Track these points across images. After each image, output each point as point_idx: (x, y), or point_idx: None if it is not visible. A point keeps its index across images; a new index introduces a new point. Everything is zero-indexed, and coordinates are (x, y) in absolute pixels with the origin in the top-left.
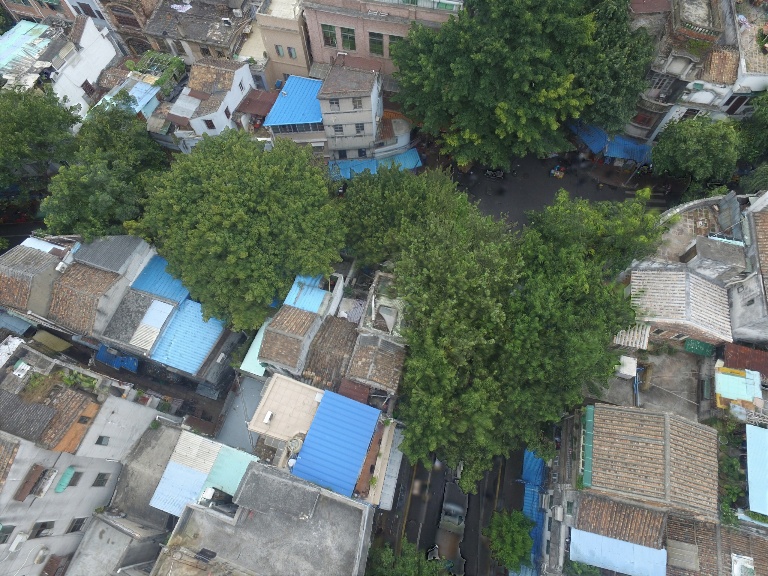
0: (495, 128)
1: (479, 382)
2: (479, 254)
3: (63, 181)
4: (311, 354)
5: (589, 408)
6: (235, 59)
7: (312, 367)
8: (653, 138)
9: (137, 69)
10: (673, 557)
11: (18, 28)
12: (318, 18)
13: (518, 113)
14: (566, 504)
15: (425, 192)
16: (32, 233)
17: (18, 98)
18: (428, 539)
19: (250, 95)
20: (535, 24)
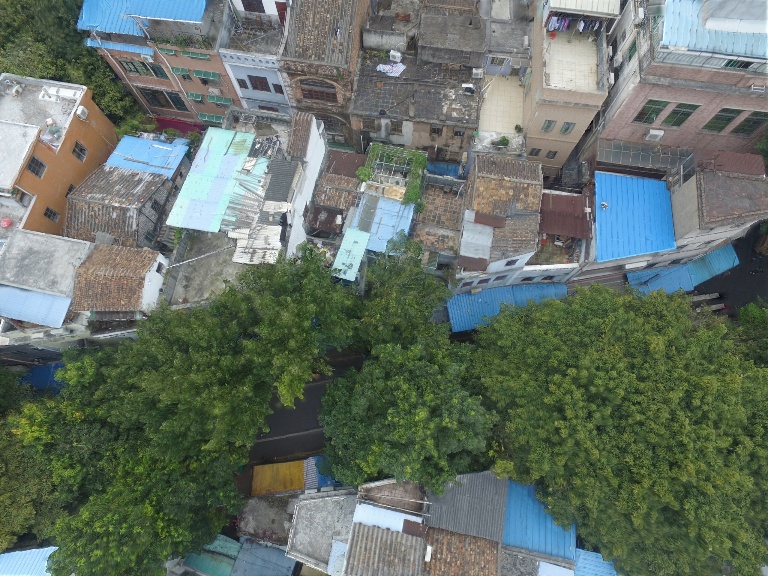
0: None
1: None
2: None
3: (428, 437)
4: None
5: None
6: (476, 138)
7: None
8: None
9: (369, 176)
10: None
11: (212, 144)
12: (650, 93)
13: None
14: None
15: None
16: (359, 495)
17: (282, 281)
18: None
19: None
20: None
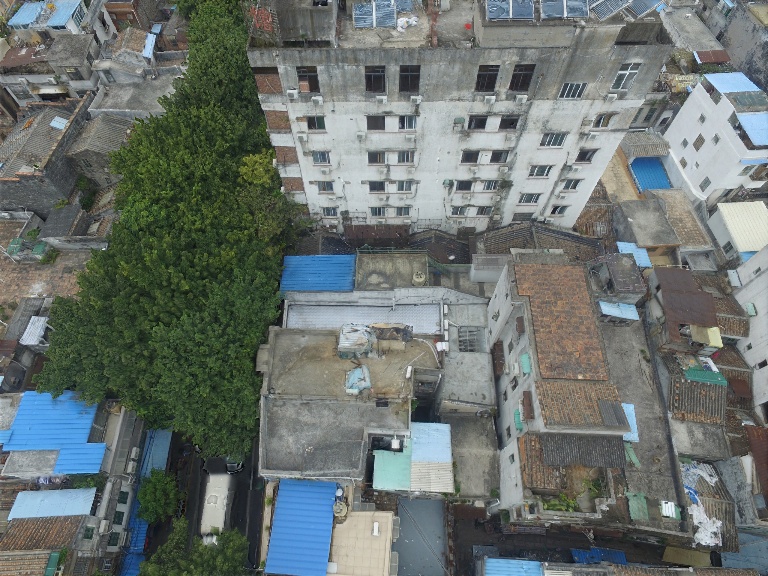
0: None
1: None
2: None
3: None
4: None
5: None
6: None
7: None
8: None
9: None
10: (6, 518)
11: None
12: None
13: None
14: (94, 537)
15: None
16: None
17: None
18: (243, 479)
19: None
20: None
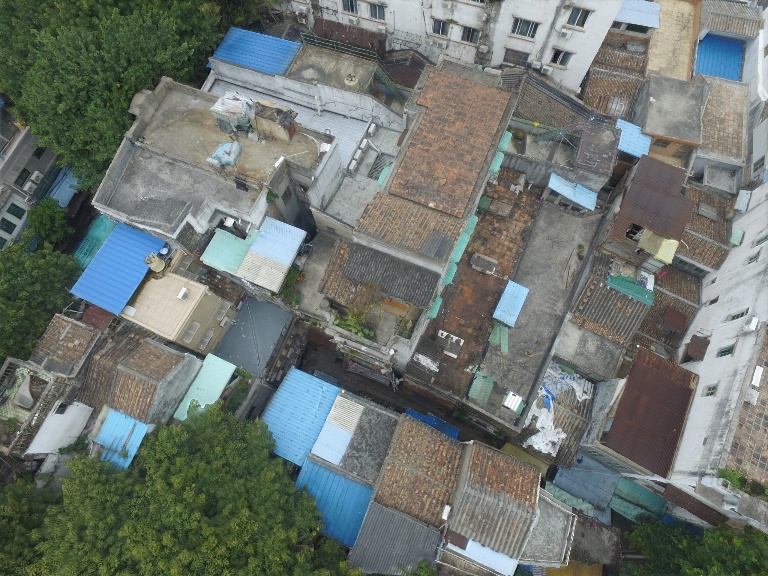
0: None
1: None
2: None
3: None
4: None
5: None
6: None
7: None
8: None
9: None
10: None
11: None
12: None
13: None
14: None
15: None
16: None
17: None
18: None
19: None
20: None
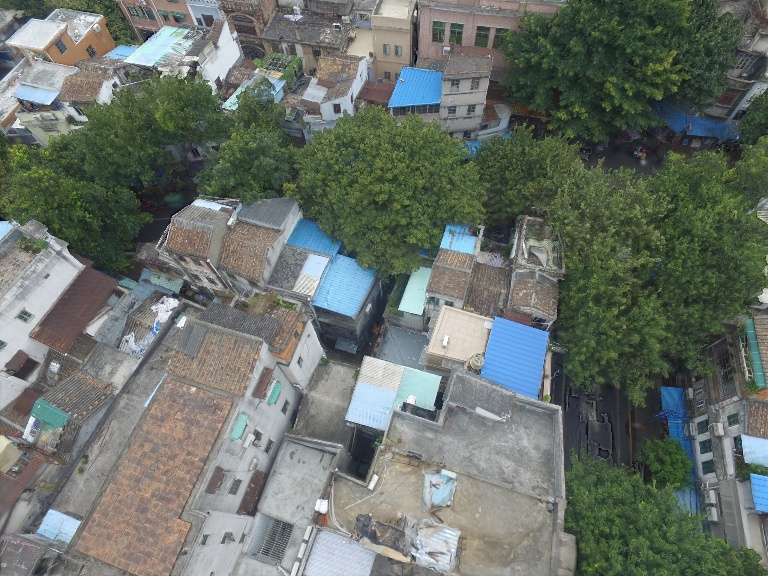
0: (600, 103)
1: (644, 300)
2: (624, 194)
3: (236, 146)
4: (469, 291)
5: (747, 321)
6: None
7: (471, 303)
8: (733, 116)
9: (262, 67)
10: None
11: (163, 31)
12: (431, 16)
13: (626, 86)
14: (726, 419)
15: (557, 150)
16: None
17: (179, 83)
18: None
19: (367, 85)
20: (642, 7)
